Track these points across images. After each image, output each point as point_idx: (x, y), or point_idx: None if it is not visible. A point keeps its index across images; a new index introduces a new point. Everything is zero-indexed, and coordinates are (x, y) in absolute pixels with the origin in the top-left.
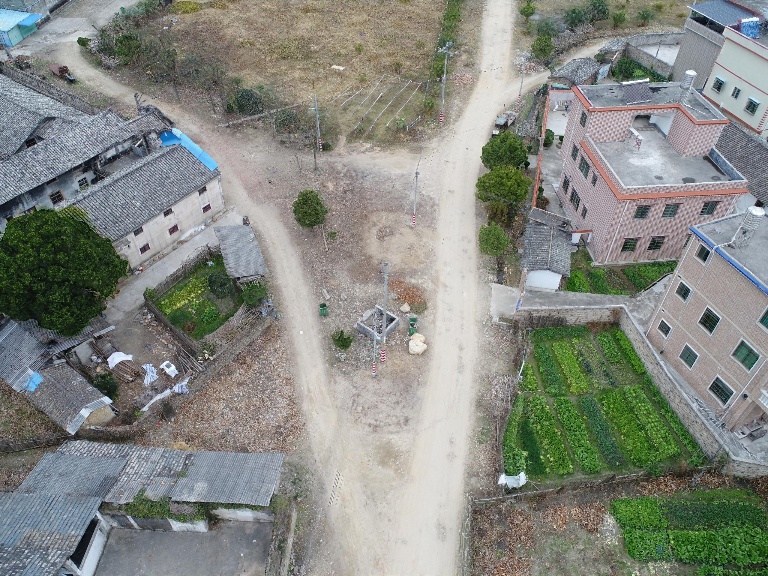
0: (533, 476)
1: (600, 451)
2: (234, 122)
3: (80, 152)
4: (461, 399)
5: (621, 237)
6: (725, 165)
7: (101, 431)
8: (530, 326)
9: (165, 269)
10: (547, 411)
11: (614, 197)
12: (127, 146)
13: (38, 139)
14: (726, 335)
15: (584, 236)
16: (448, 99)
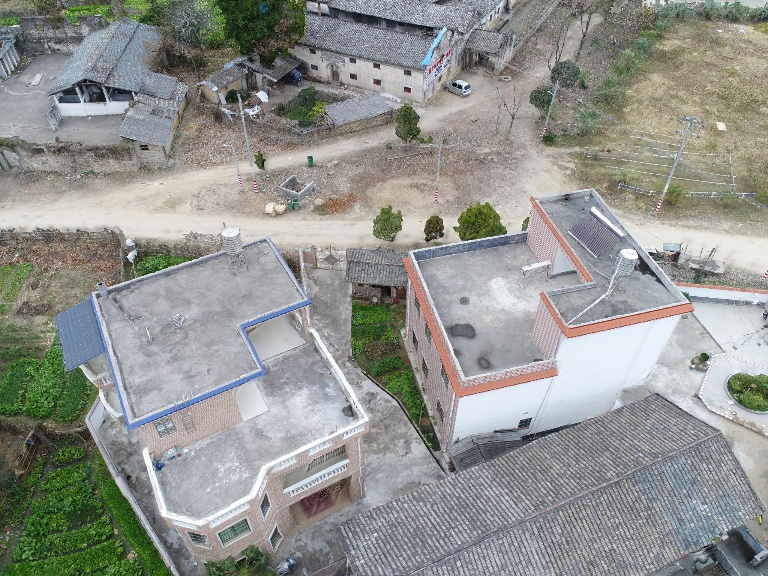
0: (142, 273)
1: None
2: None
3: (427, 19)
4: None
5: None
6: None
7: None
8: None
9: None
10: None
11: None
12: None
13: None
14: None
15: None
16: (727, 217)
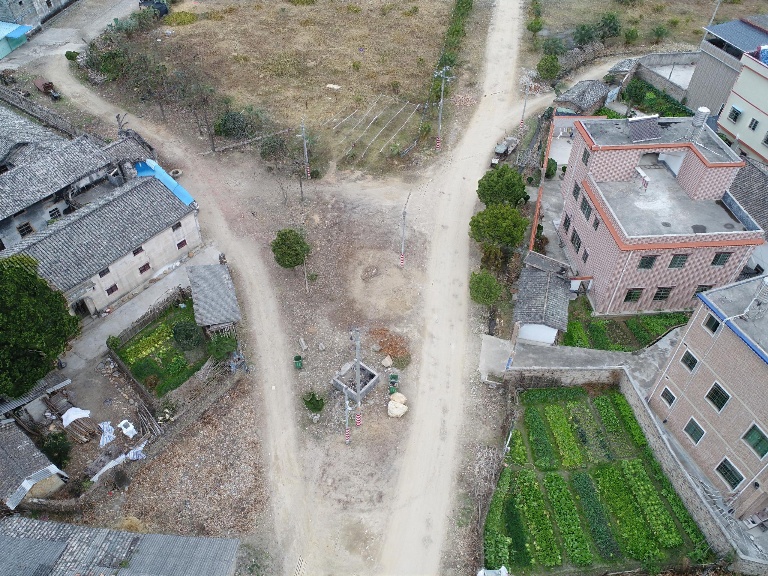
0: (517, 568)
1: (593, 539)
2: (216, 150)
3: (50, 182)
4: (442, 472)
5: (624, 287)
6: (739, 211)
7: (45, 505)
8: (521, 386)
9: (134, 311)
10: (535, 489)
11: (616, 246)
12: (102, 174)
13: (10, 165)
14: (736, 415)
15: (585, 282)
16: (447, 122)
